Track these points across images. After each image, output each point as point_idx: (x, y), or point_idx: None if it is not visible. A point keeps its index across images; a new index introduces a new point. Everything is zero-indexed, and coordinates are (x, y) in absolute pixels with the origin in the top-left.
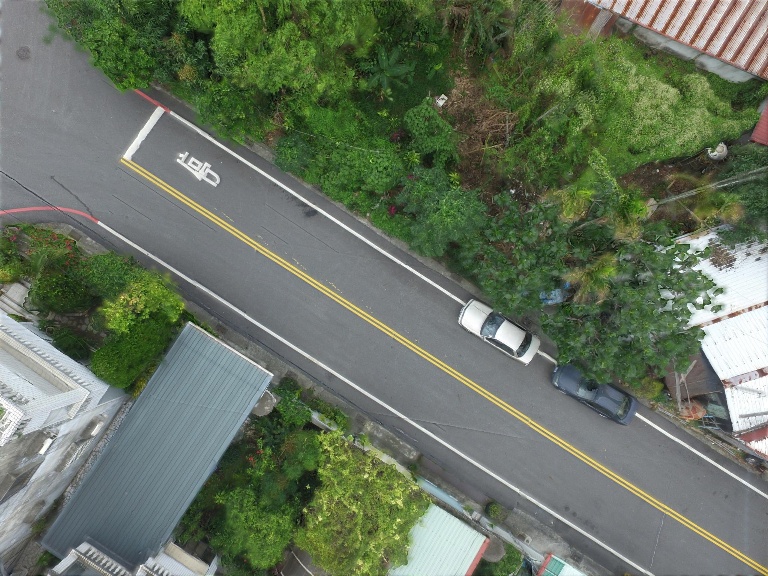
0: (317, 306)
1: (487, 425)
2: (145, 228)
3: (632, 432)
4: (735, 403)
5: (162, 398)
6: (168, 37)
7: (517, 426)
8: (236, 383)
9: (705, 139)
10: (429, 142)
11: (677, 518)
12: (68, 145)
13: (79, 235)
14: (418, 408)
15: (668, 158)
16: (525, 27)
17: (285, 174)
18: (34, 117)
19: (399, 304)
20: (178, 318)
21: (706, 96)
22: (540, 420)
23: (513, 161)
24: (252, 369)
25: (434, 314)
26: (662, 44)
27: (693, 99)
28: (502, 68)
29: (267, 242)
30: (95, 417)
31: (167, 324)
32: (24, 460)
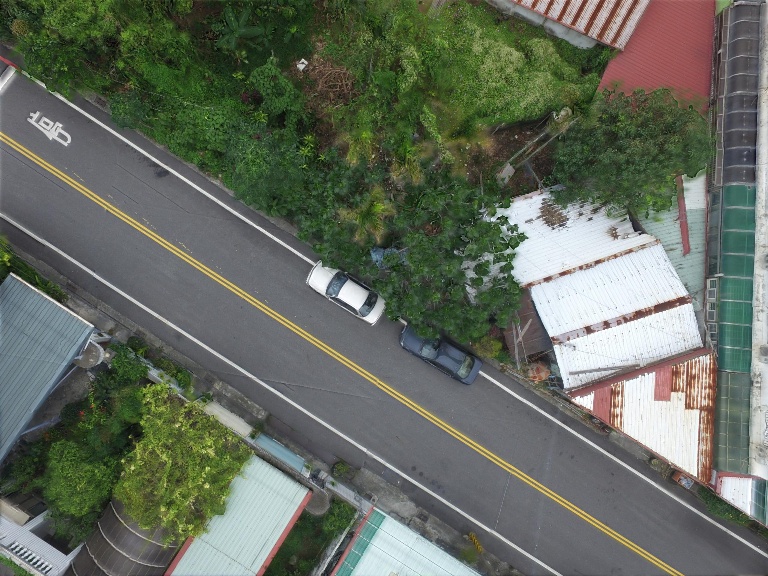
0: (167, 266)
1: (336, 385)
2: None
3: (480, 393)
4: (564, 360)
5: None
6: None
7: (365, 386)
8: (56, 334)
9: (547, 102)
10: (277, 103)
11: (523, 478)
12: None
13: None
14: (267, 368)
15: (515, 122)
16: None
17: (137, 135)
18: None
19: (250, 265)
20: (2, 270)
21: (550, 60)
22: (388, 380)
23: (348, 119)
24: (72, 320)
25: (285, 275)
26: (511, 9)
27: (537, 63)
28: None
29: (117, 202)
30: None
31: None
32: None
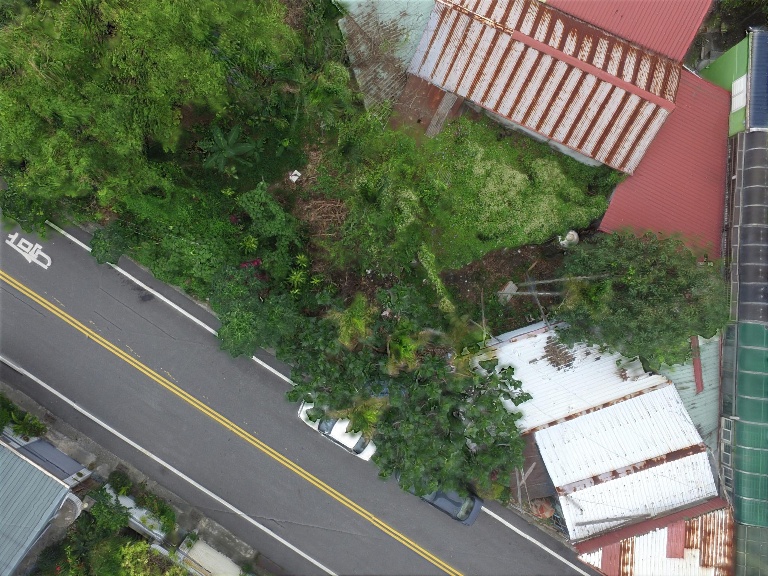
0: (151, 396)
1: (329, 522)
2: None
3: (481, 529)
4: (570, 511)
5: None
6: None
7: (360, 523)
8: (29, 496)
9: (552, 228)
10: (267, 227)
11: None
12: None
13: None
14: (256, 504)
15: None
16: (347, 119)
17: (121, 256)
18: None
19: (238, 394)
20: None
21: (556, 182)
22: (384, 517)
23: (342, 254)
24: (46, 481)
25: (275, 404)
26: (515, 126)
27: (541, 186)
28: None
29: (99, 328)
30: None
31: None
32: None
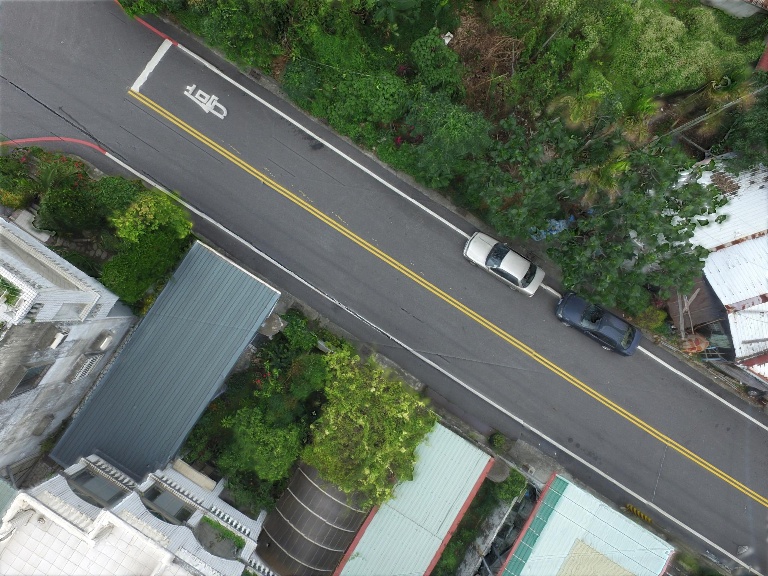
0: (323, 238)
1: (491, 357)
2: (152, 159)
3: (635, 365)
4: (738, 328)
5: (170, 315)
6: None
7: (521, 358)
8: (244, 301)
9: (710, 71)
10: (435, 74)
11: (679, 450)
12: (76, 76)
13: (87, 166)
14: (423, 340)
15: (673, 92)
16: None
17: (292, 107)
18: (42, 48)
19: (405, 237)
20: (186, 238)
21: (711, 29)
22: (544, 352)
23: (519, 88)
24: (260, 287)
25: (439, 247)
26: None
27: (698, 32)
28: (508, 2)
29: (274, 174)
30: (104, 330)
31: (175, 242)
32: (36, 355)
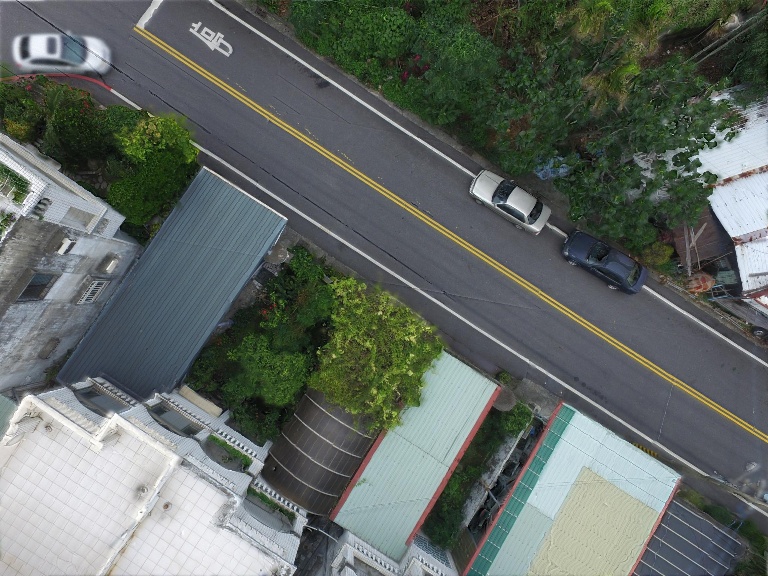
0: (329, 176)
1: (497, 296)
2: None
3: (641, 305)
4: (745, 261)
5: (177, 240)
6: None
7: (527, 297)
8: (250, 227)
9: (717, 7)
10: (442, 11)
11: (685, 389)
12: (81, 12)
13: (92, 102)
14: (429, 278)
15: (679, 30)
16: None
17: (297, 46)
18: None
19: (410, 175)
20: (192, 165)
21: None
22: (550, 291)
23: (526, 20)
24: (266, 213)
25: (445, 186)
26: None
27: None
28: None
29: (279, 112)
30: (110, 252)
31: (182, 167)
32: (43, 261)
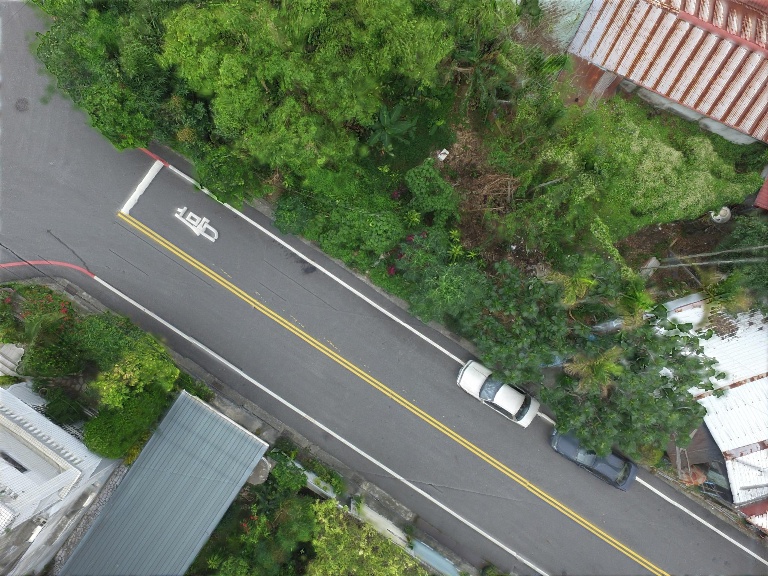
0: (314, 364)
1: (485, 487)
2: (142, 283)
3: (631, 496)
4: (736, 475)
5: (155, 468)
6: (168, 99)
7: (515, 489)
8: (231, 453)
9: (708, 203)
10: (430, 201)
11: None
12: (65, 199)
13: (75, 290)
14: (415, 469)
15: (671, 220)
16: (528, 95)
17: None
18: (31, 170)
19: (397, 363)
20: (173, 385)
21: (710, 159)
22: (538, 483)
23: (514, 226)
24: (247, 439)
25: (432, 374)
26: (666, 105)
27: (697, 162)
28: None
29: (265, 299)
30: (87, 489)
31: (162, 392)
32: (13, 547)
